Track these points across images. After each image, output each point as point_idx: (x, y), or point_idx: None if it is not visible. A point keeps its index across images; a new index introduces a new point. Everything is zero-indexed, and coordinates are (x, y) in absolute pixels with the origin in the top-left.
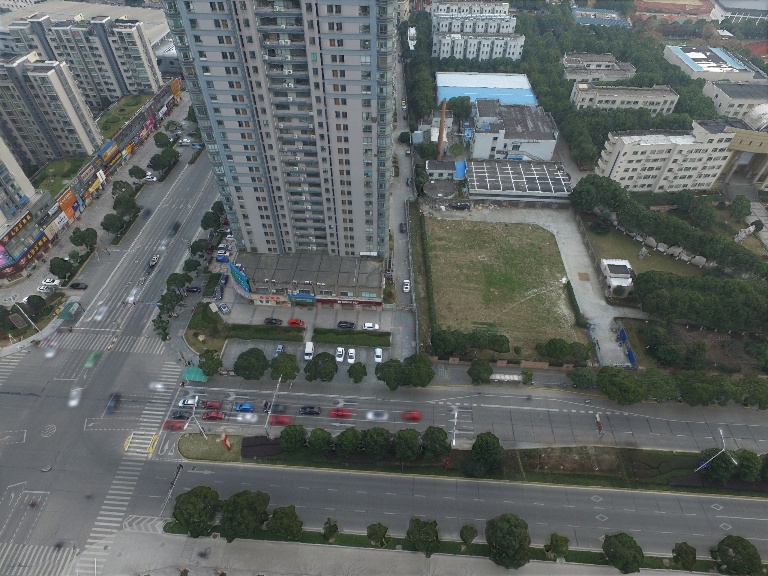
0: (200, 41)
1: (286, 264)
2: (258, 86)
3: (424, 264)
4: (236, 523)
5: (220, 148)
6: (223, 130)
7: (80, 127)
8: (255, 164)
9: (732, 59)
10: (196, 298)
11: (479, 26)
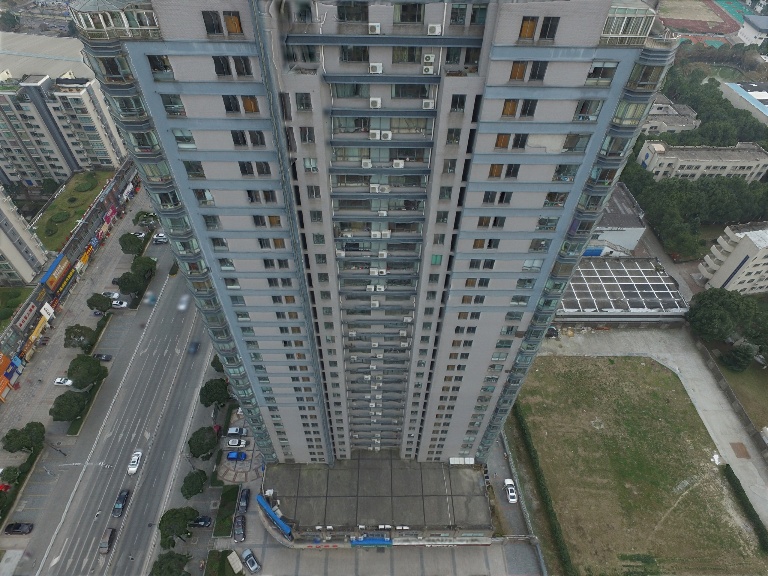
0: (223, 244)
1: (341, 484)
2: (324, 296)
3: (523, 443)
4: None
5: (248, 369)
6: (255, 351)
7: (11, 249)
8: (305, 384)
9: None
10: (205, 538)
11: None
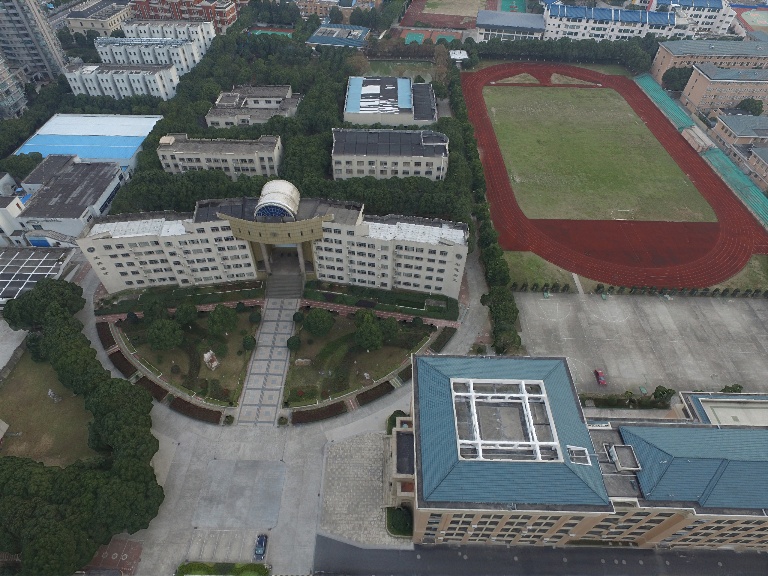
0: None
1: None
2: None
3: None
4: None
5: None
6: None
7: None
8: None
9: (409, 94)
10: None
11: (145, 53)
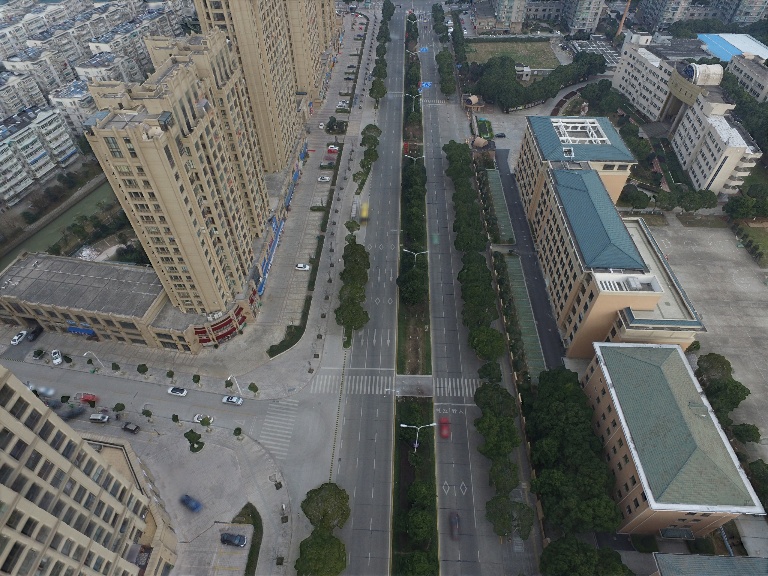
0: None
1: (486, 7)
2: None
3: None
4: (384, 6)
5: None
6: None
7: None
8: None
9: None
10: None
11: None
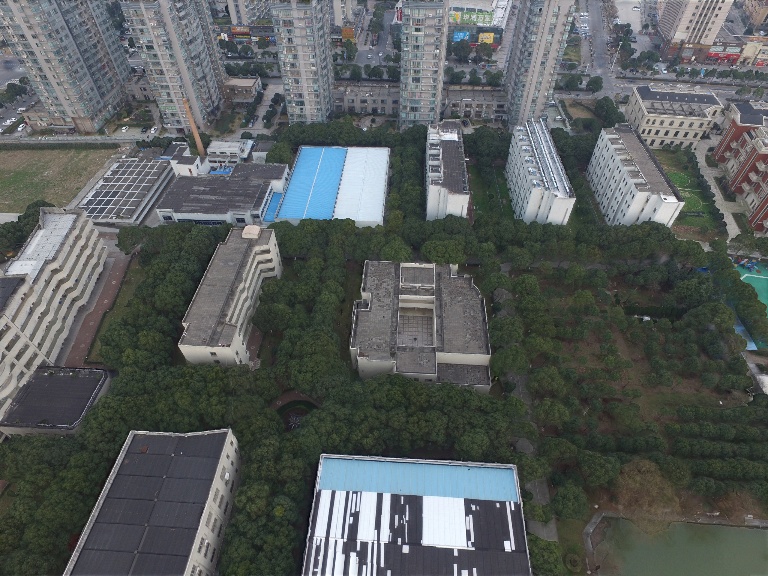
0: None
1: None
2: None
3: None
4: None
5: None
6: None
7: (233, 5)
8: None
9: None
10: None
11: None
